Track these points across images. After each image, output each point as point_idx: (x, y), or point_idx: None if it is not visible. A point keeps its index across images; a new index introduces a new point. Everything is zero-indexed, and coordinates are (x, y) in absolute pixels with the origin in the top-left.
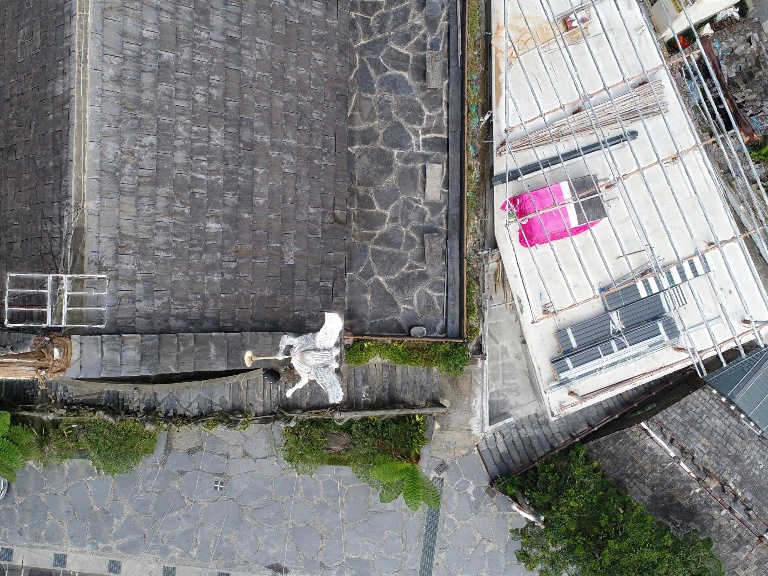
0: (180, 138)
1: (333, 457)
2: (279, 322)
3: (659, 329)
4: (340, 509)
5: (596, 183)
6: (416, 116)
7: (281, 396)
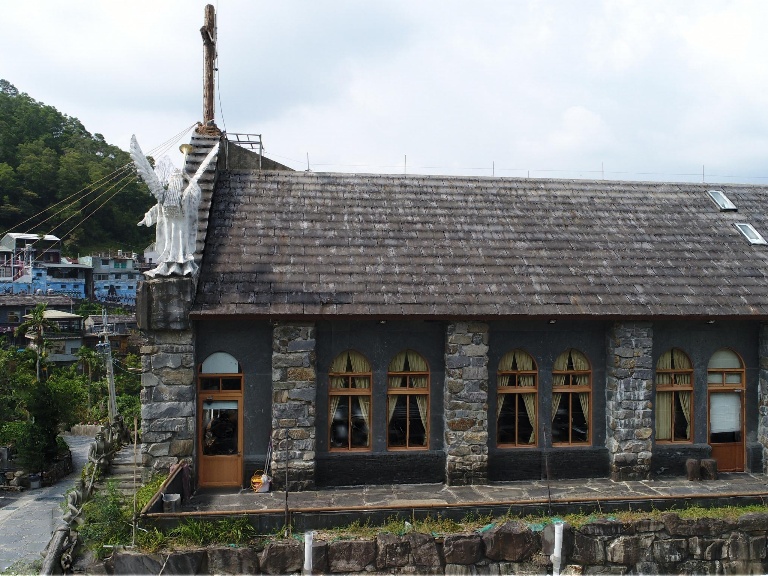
0: None
1: None
2: (214, 264)
3: None
4: None
5: None
6: None
7: None
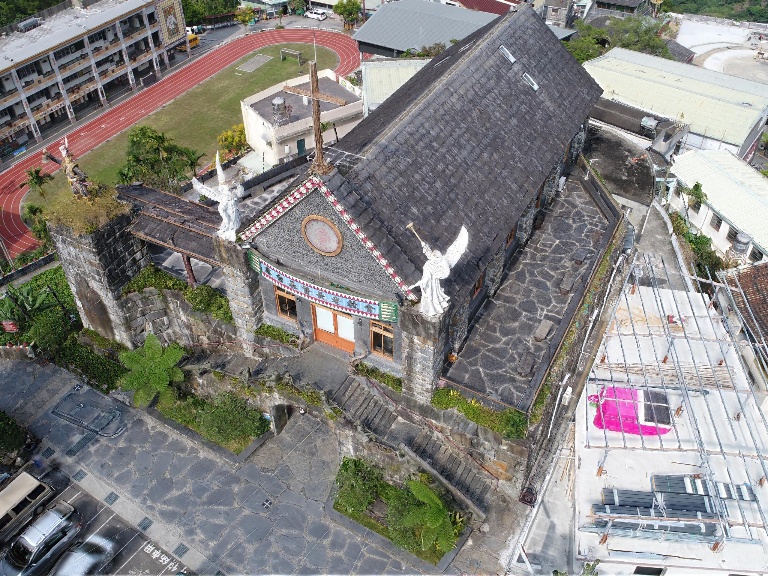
0: (422, 171)
1: (371, 521)
2: None
3: (697, 516)
4: (352, 570)
5: (666, 400)
6: (546, 302)
7: (367, 422)
